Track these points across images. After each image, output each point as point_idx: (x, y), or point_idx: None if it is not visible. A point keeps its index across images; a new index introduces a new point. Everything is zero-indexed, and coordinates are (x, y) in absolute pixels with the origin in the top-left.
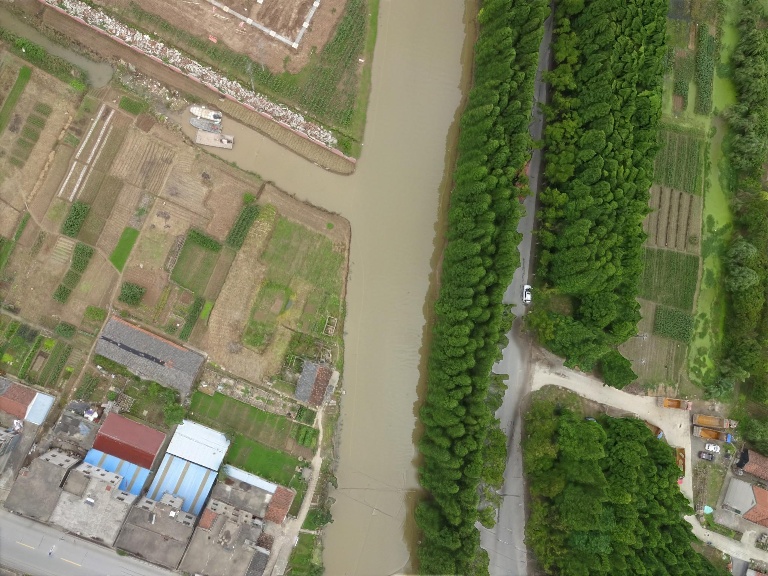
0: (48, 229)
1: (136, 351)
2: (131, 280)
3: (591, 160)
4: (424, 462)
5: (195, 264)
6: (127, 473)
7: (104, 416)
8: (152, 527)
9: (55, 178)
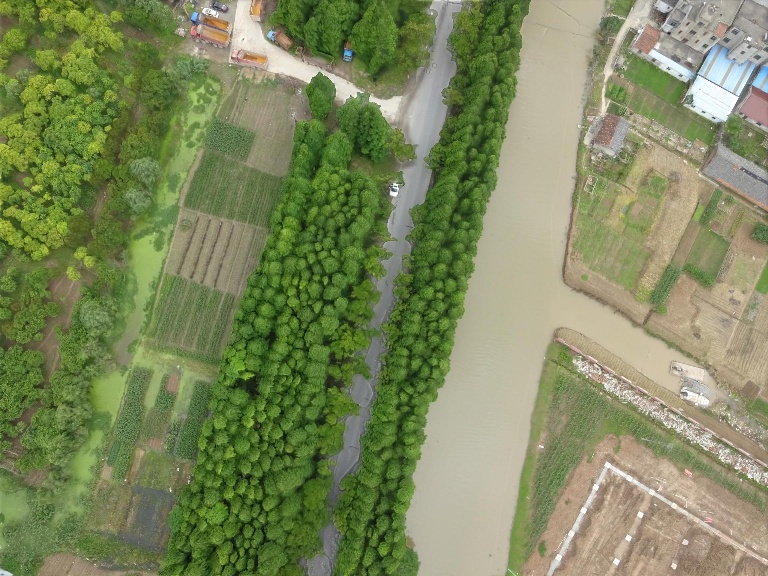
0: None
1: (764, 182)
2: (762, 247)
3: (340, 296)
4: None
5: (708, 256)
6: None
7: None
8: (765, 32)
9: None
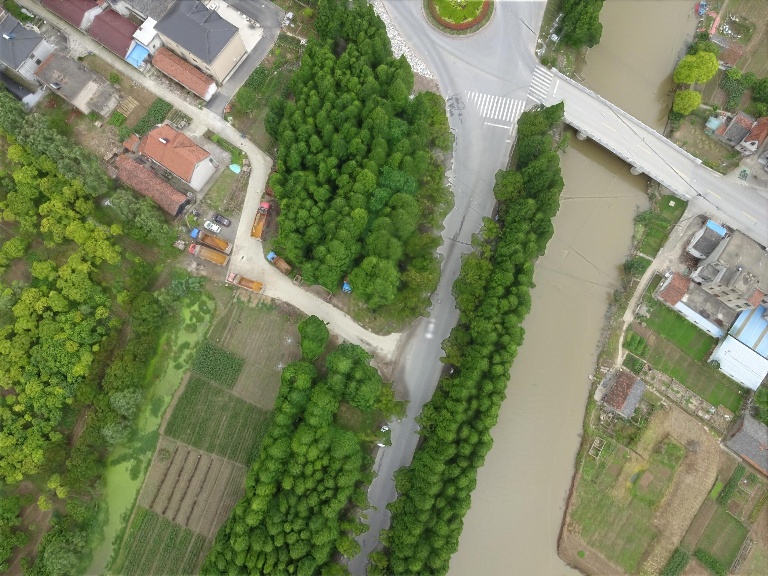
0: None
1: None
2: None
3: None
4: None
5: (722, 541)
6: None
7: None
8: None
9: None
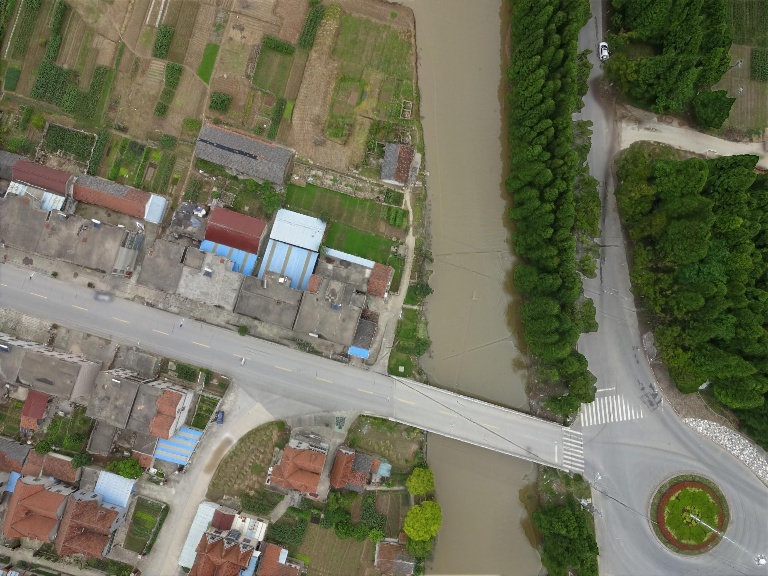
0: (141, 54)
1: (231, 149)
2: (218, 90)
3: None
4: (517, 231)
5: (273, 69)
6: (238, 259)
7: (211, 212)
8: (265, 293)
9: (141, 8)
